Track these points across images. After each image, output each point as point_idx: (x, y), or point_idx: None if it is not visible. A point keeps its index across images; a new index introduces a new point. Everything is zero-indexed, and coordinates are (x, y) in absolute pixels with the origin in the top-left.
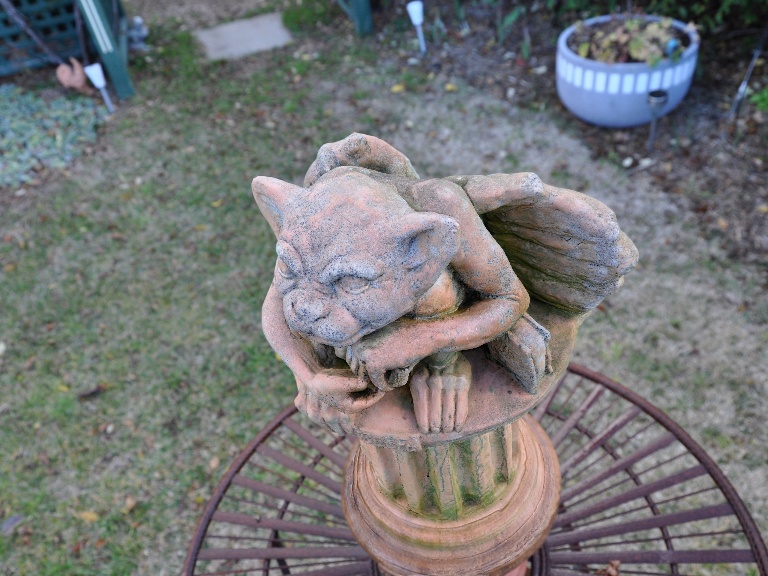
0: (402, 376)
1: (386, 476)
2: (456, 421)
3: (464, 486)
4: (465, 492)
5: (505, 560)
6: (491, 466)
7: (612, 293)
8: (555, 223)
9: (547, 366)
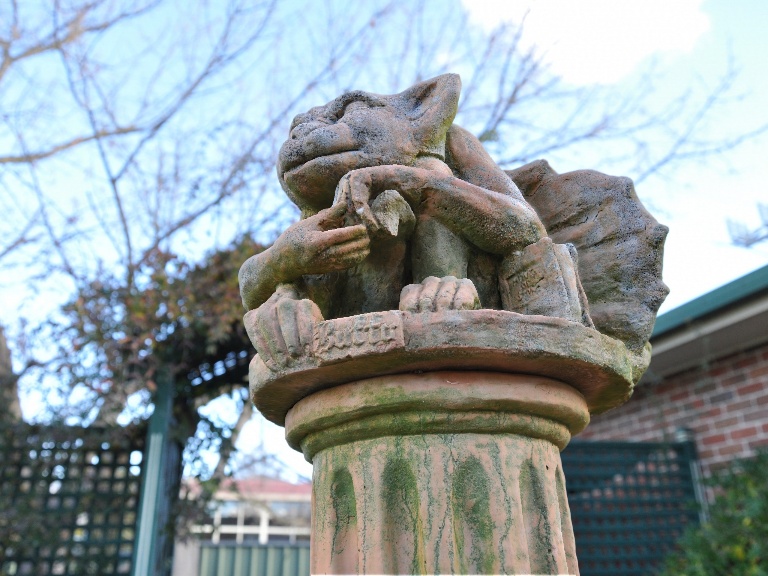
0: (390, 194)
1: None
2: (455, 296)
3: None
4: None
5: None
6: None
7: (657, 296)
8: (567, 200)
9: (584, 311)
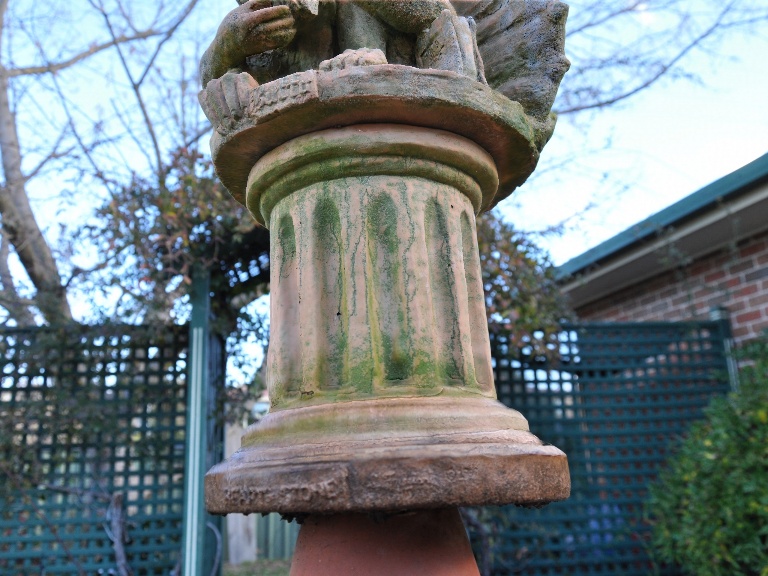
0: None
1: (283, 338)
2: None
3: (389, 337)
4: (390, 354)
5: (441, 448)
6: (429, 296)
7: (558, 68)
8: None
9: (479, 73)
